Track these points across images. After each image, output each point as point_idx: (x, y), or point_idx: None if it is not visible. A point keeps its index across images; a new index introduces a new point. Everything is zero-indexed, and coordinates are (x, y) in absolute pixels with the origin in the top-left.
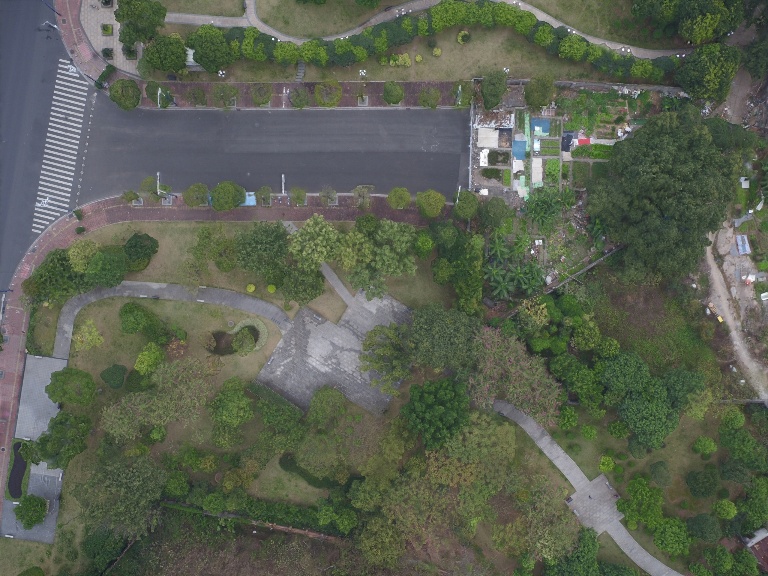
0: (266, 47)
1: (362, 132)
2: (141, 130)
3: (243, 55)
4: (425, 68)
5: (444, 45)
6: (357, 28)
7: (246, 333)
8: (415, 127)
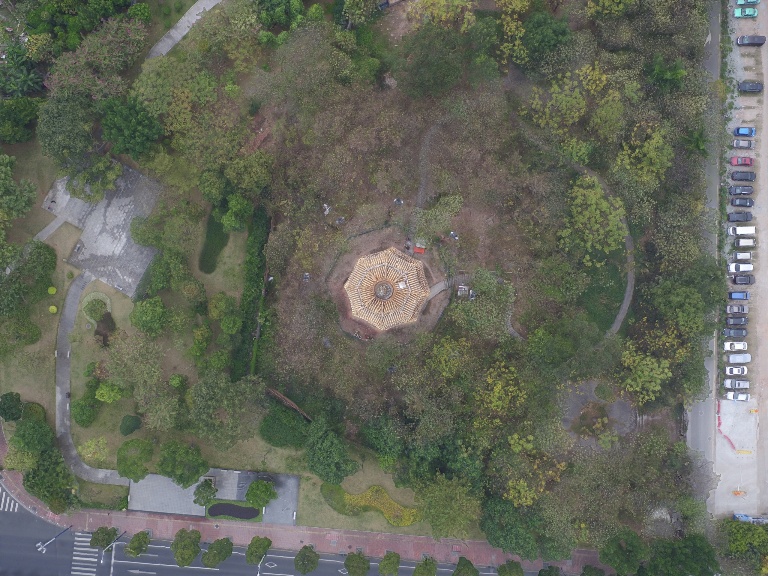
0: None
1: None
2: None
3: None
4: None
5: None
6: None
7: (85, 308)
8: None
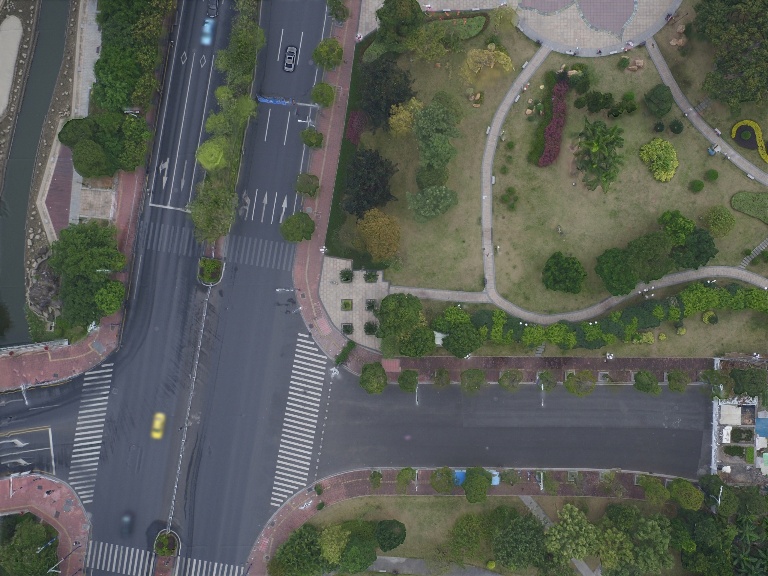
0: (515, 333)
1: (602, 407)
2: (380, 404)
3: (490, 339)
4: (667, 345)
5: (688, 324)
6: (598, 304)
7: None
8: (656, 403)
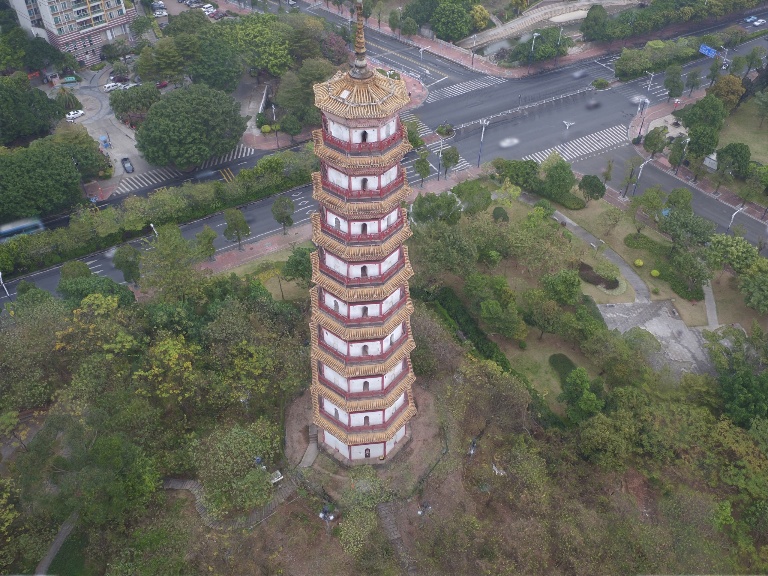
0: None
1: None
2: None
3: (753, 173)
4: None
5: None
6: None
7: None
8: None
